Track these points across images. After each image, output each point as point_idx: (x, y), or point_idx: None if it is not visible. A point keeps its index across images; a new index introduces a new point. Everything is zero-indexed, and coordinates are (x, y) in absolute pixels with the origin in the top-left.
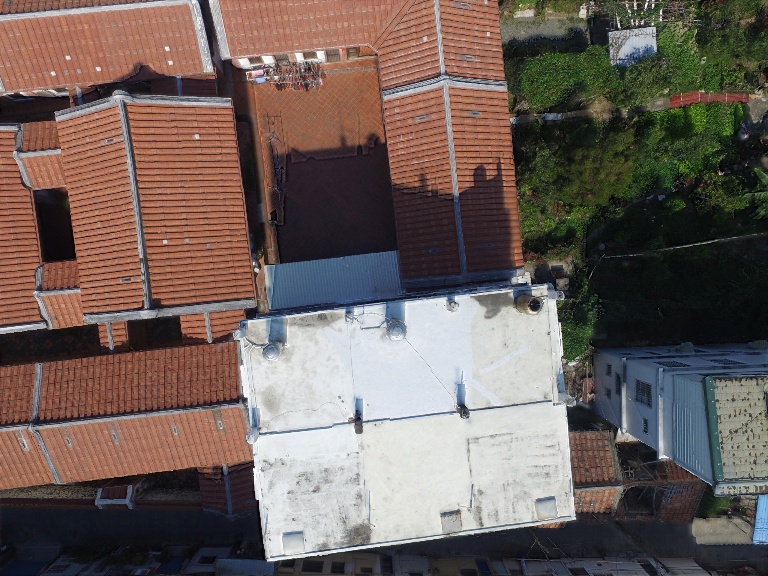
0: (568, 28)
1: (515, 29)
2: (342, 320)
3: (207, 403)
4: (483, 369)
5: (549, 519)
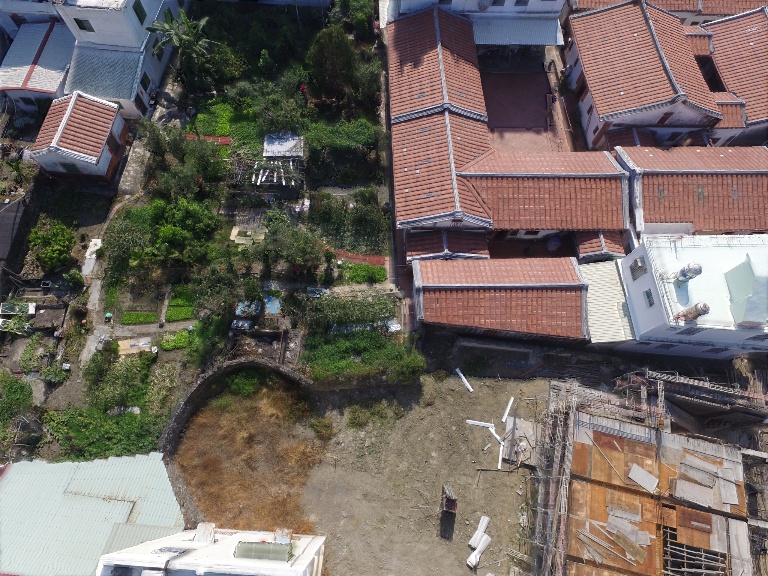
0: None
1: None
2: None
3: None
4: None
5: None
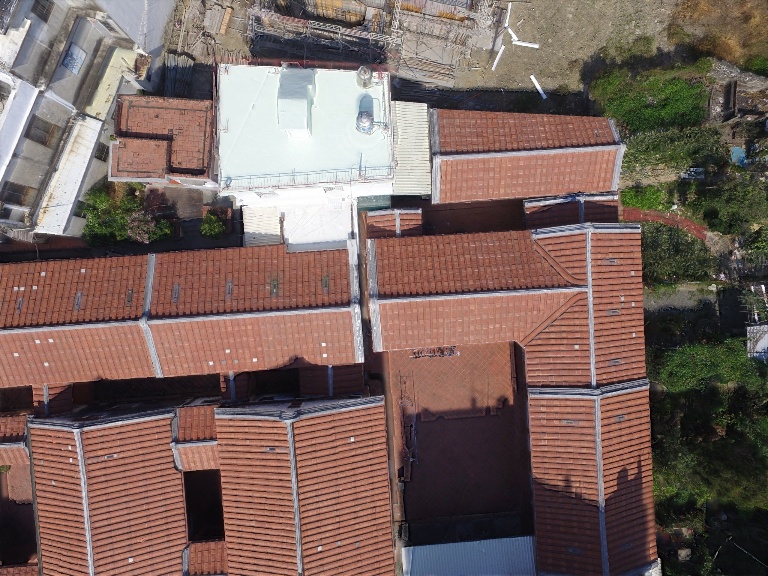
0: (698, 299)
1: (646, 299)
2: None
3: None
4: None
5: None
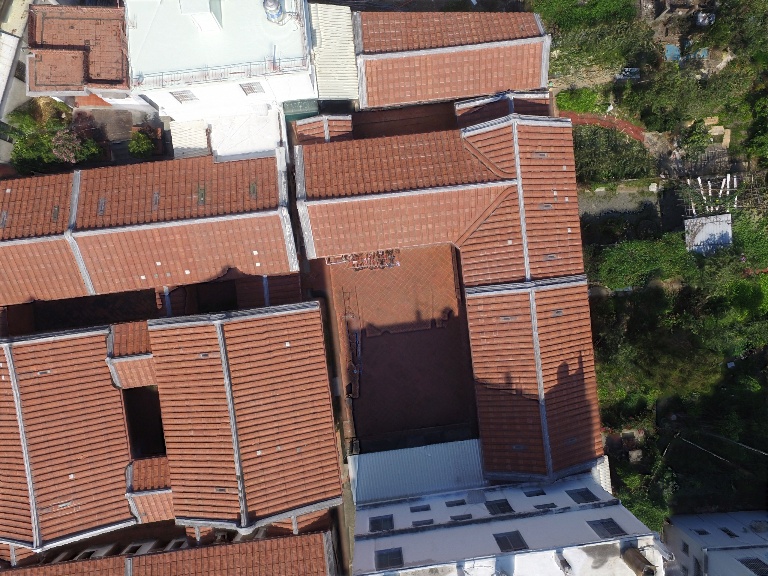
0: (638, 201)
1: (586, 203)
2: (453, 573)
3: None
4: None
5: None
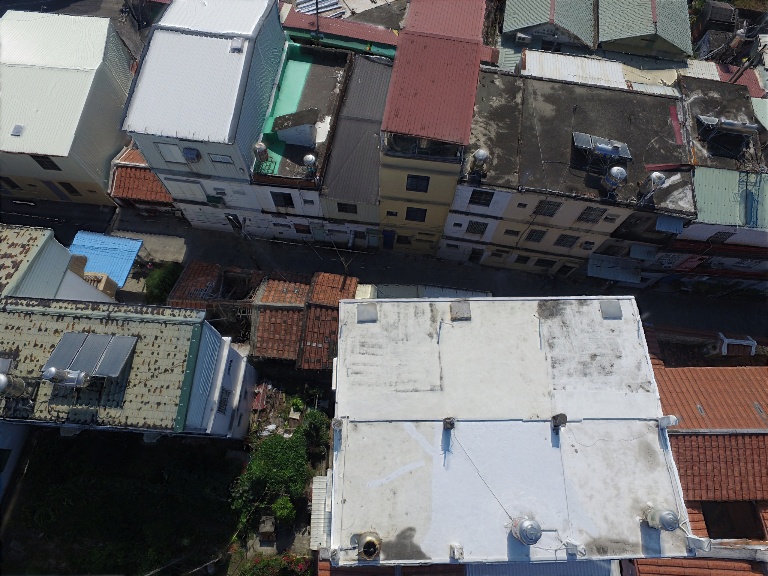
0: None
1: None
2: None
3: (675, 437)
4: (421, 466)
5: (366, 303)
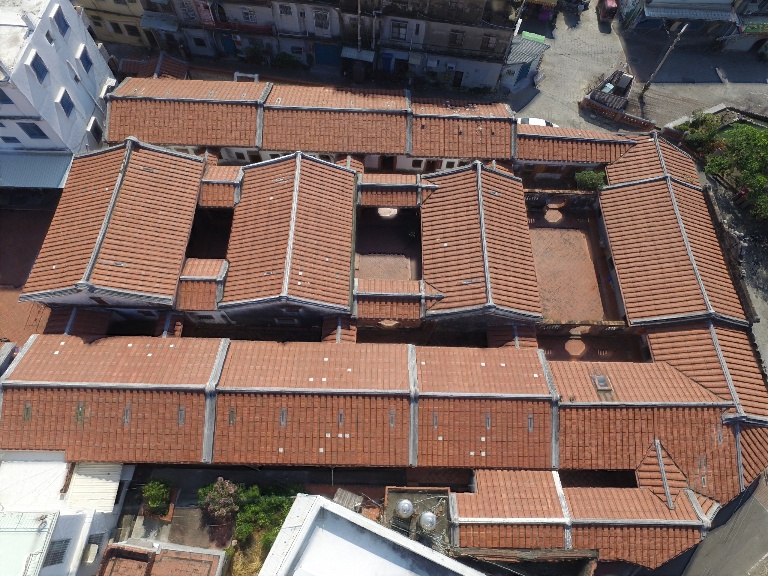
0: None
1: None
2: None
3: (134, 100)
4: None
5: None
